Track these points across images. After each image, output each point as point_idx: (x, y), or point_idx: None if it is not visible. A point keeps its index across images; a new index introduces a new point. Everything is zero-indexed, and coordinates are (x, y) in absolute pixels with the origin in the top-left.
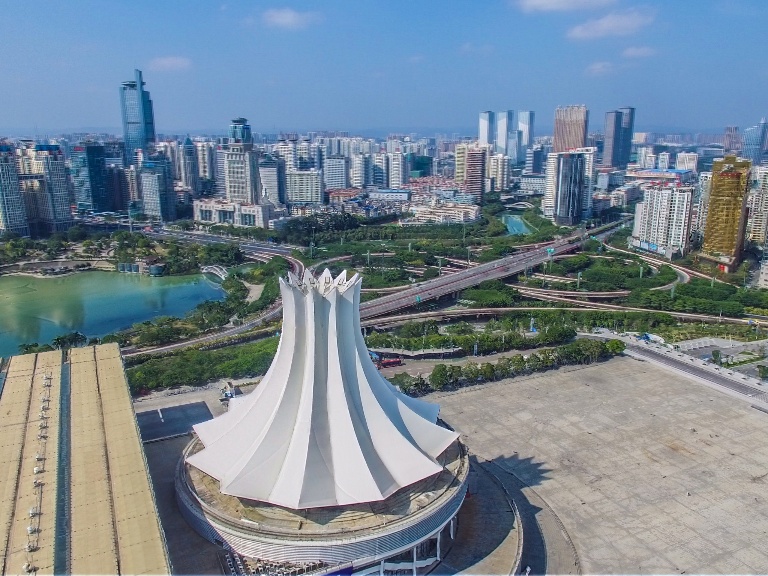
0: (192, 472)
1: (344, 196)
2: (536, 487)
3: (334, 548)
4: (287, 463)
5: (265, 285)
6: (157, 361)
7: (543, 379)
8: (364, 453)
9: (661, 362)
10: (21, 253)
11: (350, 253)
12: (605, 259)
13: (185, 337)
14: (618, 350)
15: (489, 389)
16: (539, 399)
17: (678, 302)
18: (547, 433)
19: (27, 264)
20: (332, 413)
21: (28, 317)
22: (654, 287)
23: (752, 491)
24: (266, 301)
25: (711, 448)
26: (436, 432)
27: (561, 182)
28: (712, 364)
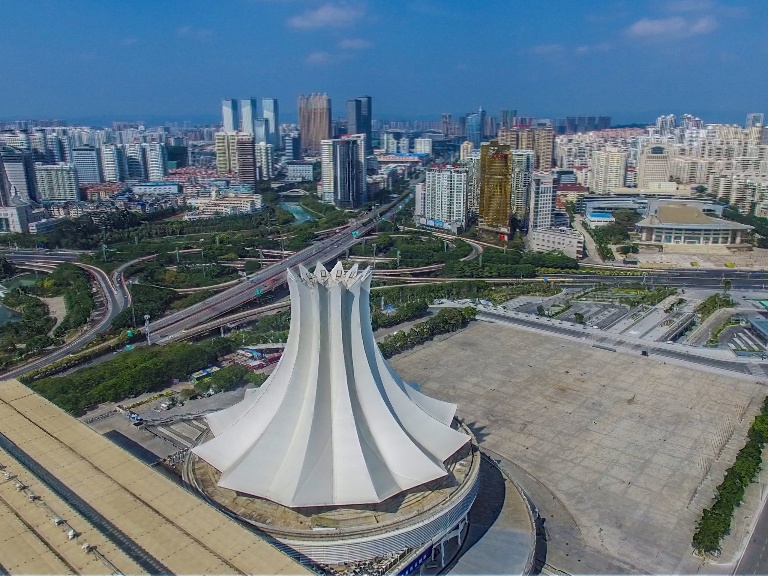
0: (216, 498)
1: (105, 192)
2: (483, 444)
3: (417, 531)
4: (337, 463)
5: (67, 297)
6: None
7: (426, 350)
8: None
9: (505, 321)
10: None
11: (152, 252)
12: None
13: None
14: (473, 316)
15: None
16: (435, 368)
17: (486, 269)
18: (461, 396)
19: None
20: (365, 405)
21: None
22: (460, 258)
23: (634, 411)
24: (86, 314)
25: (587, 384)
26: (439, 406)
27: (339, 168)
28: (543, 317)
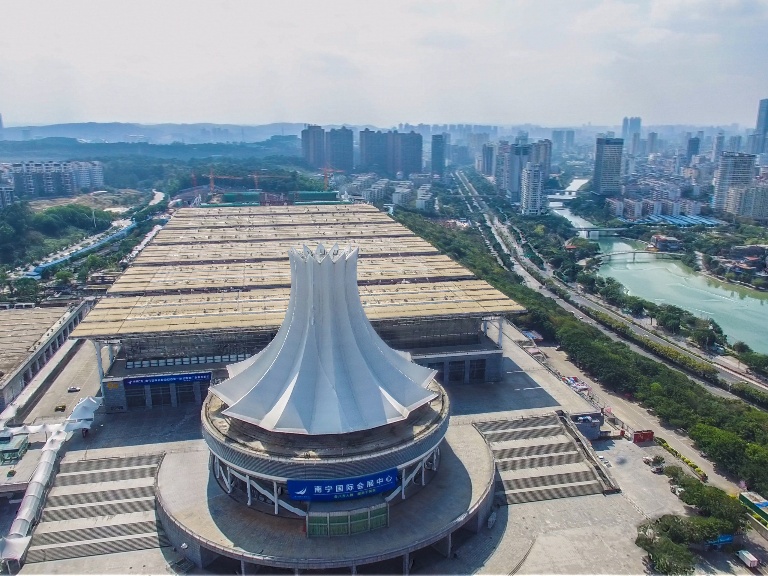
0: None
1: None
2: None
3: None
4: None
5: None
6: None
7: None
8: (247, 371)
9: None
10: None
11: None
12: None
13: None
14: None
15: None
16: None
17: None
18: None
19: None
20: None
21: None
22: None
23: None
24: None
25: None
26: None
27: None
28: None
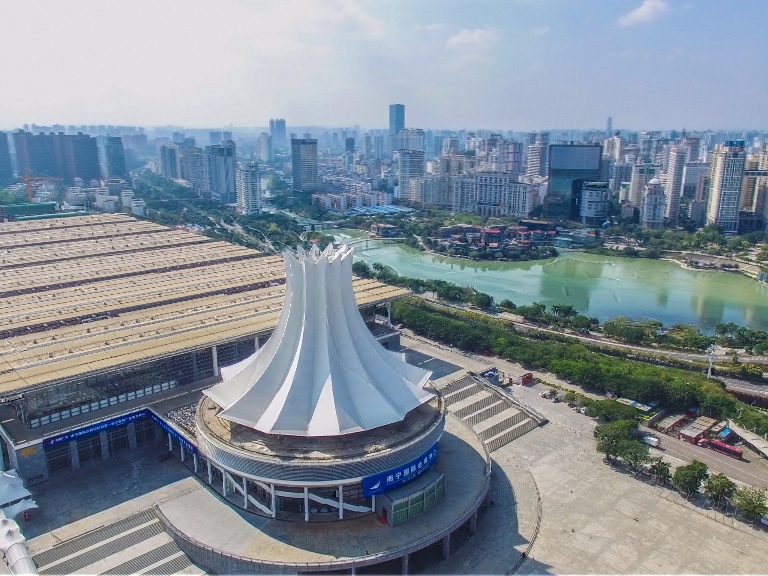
0: None
1: None
2: None
3: None
4: None
5: None
6: (551, 342)
7: None
8: (255, 388)
9: None
10: (694, 243)
11: None
12: None
13: (657, 345)
14: None
15: (746, 537)
16: None
17: None
18: None
19: (689, 254)
20: None
21: (610, 292)
22: None
23: None
24: None
25: None
26: (331, 420)
27: None
28: None
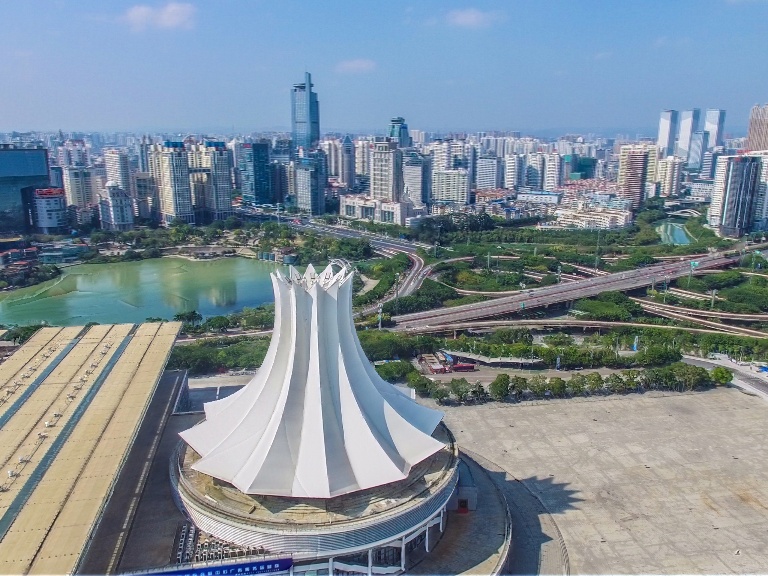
0: None
1: (490, 197)
2: (557, 515)
3: (275, 537)
4: (258, 449)
5: (380, 280)
6: (246, 343)
7: (620, 402)
8: (327, 449)
9: None
10: (182, 238)
11: (473, 254)
12: (761, 277)
13: None
14: (723, 380)
15: (554, 406)
16: (605, 423)
17: None
18: (597, 460)
19: (185, 248)
20: (308, 406)
21: (170, 294)
22: None
23: None
24: (371, 296)
25: None
26: (420, 439)
27: (729, 189)
28: None
